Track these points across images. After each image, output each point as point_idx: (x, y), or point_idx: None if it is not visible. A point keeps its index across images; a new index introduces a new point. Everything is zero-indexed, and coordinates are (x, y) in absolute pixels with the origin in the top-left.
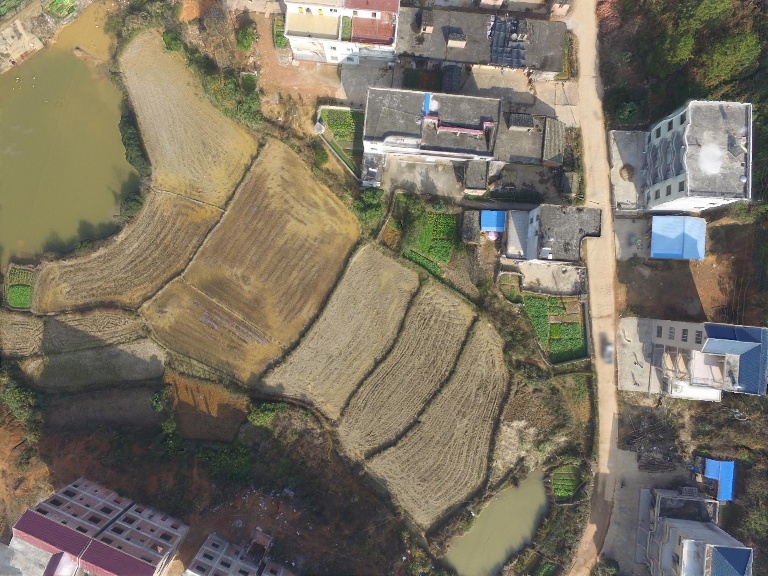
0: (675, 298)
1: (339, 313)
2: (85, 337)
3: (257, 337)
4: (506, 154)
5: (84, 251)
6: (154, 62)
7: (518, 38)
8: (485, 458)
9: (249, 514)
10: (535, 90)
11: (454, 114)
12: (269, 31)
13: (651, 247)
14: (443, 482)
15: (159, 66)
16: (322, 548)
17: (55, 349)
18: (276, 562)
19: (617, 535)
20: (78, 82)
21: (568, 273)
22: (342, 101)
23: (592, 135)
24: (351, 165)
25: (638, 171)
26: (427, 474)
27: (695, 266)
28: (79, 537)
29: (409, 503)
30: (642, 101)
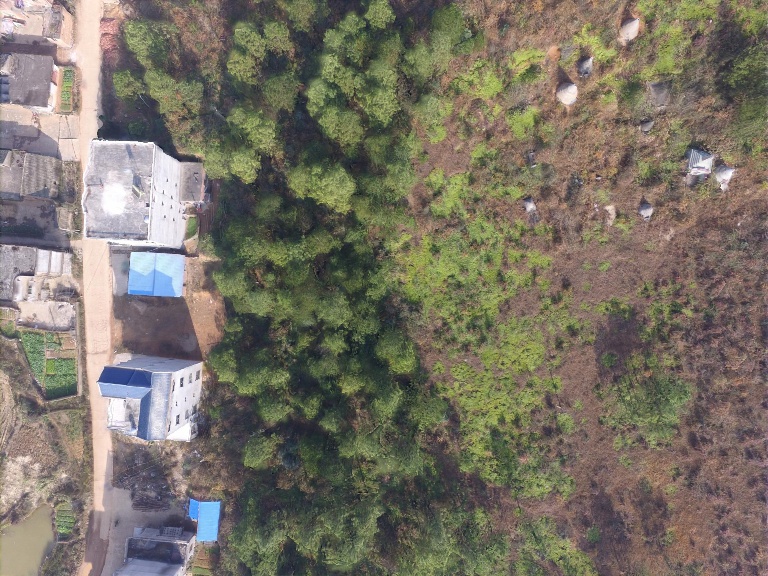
0: (171, 334)
1: None
2: None
3: None
4: None
5: None
6: None
7: (1, 73)
8: None
9: None
10: (39, 123)
11: None
12: None
13: (128, 284)
14: None
15: None
16: None
17: None
18: None
19: (111, 574)
20: None
21: (65, 308)
22: None
23: None
24: None
25: None
26: None
27: (192, 302)
28: None
29: None
30: None
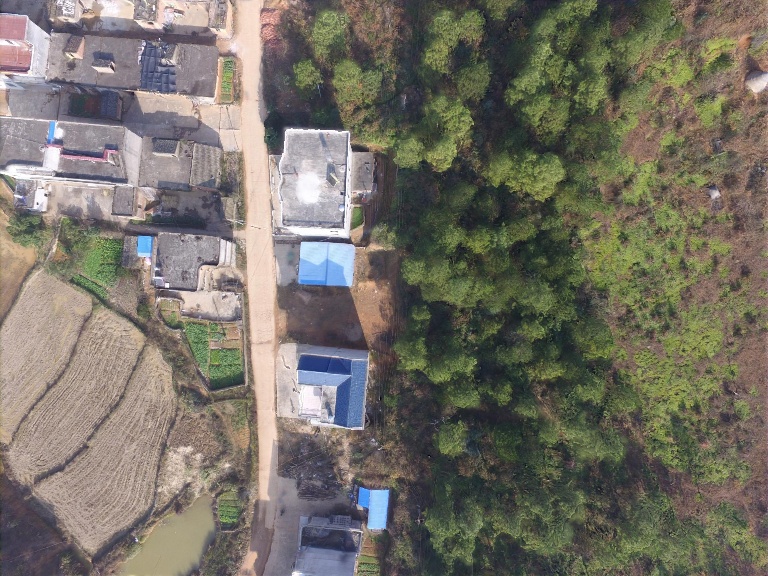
0: (336, 324)
1: (13, 338)
2: None
3: None
4: (154, 180)
5: None
6: None
7: (168, 63)
8: (153, 484)
9: None
10: (200, 114)
11: (79, 142)
12: None
13: (299, 273)
14: (110, 507)
15: None
16: None
17: None
18: None
19: (277, 563)
20: None
21: (228, 299)
22: None
23: (254, 159)
24: None
25: None
26: (94, 499)
27: (356, 292)
28: None
29: (76, 528)
30: (297, 125)
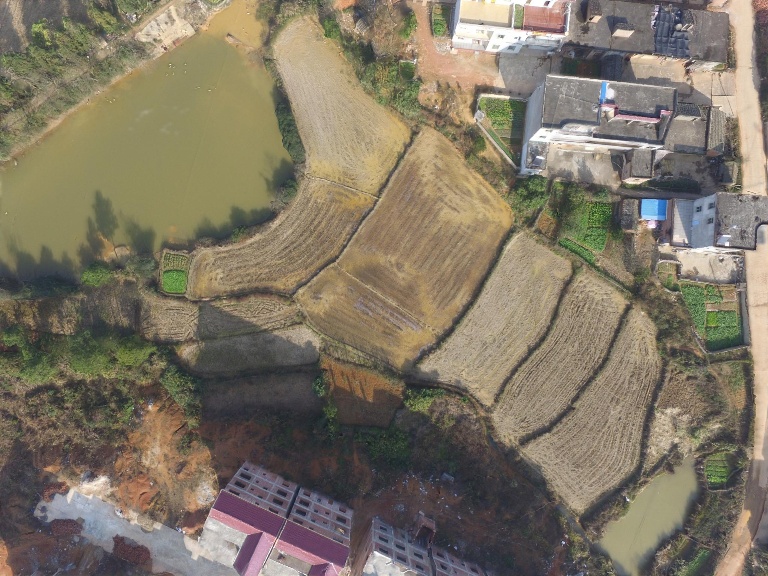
0: None
1: (493, 300)
2: (240, 322)
3: (411, 324)
4: (670, 143)
5: (241, 237)
6: (307, 49)
7: (682, 28)
8: (638, 444)
9: (411, 498)
10: (692, 80)
11: (630, 102)
12: (426, 19)
13: None
14: (597, 468)
15: (312, 53)
16: (483, 532)
17: (210, 334)
18: (439, 546)
19: None
20: (229, 69)
21: (725, 262)
22: (500, 90)
23: (749, 125)
24: (509, 153)
25: None
26: (581, 460)
27: None
28: (274, 518)
29: (563, 489)
30: None
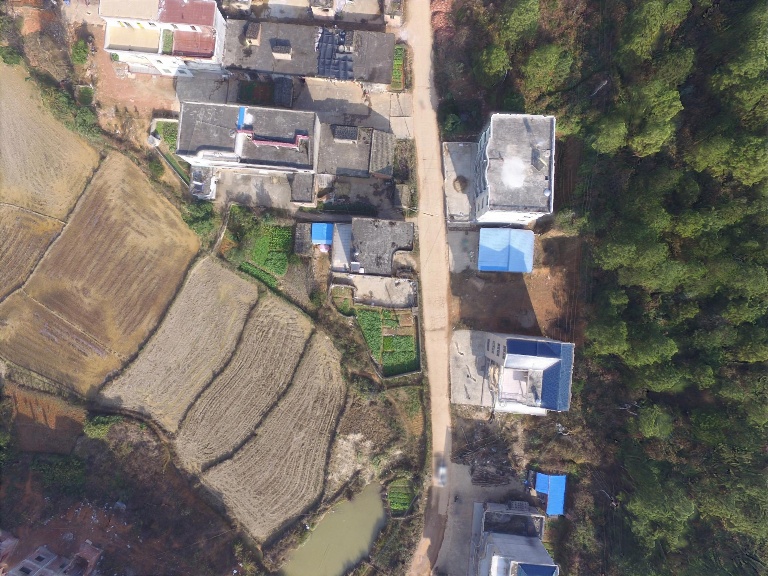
0: (509, 311)
1: (178, 325)
2: None
3: (97, 349)
4: (333, 167)
5: None
6: None
7: (346, 50)
8: (322, 471)
9: (80, 527)
10: (370, 101)
11: (269, 127)
12: None
13: (478, 260)
14: (279, 495)
15: (2, 79)
16: (152, 561)
17: None
18: (105, 575)
19: (450, 549)
20: None
21: (401, 286)
22: (177, 113)
23: (426, 146)
24: (186, 178)
25: (471, 183)
26: (263, 487)
27: (529, 278)
28: None
29: (245, 516)
30: (473, 112)
